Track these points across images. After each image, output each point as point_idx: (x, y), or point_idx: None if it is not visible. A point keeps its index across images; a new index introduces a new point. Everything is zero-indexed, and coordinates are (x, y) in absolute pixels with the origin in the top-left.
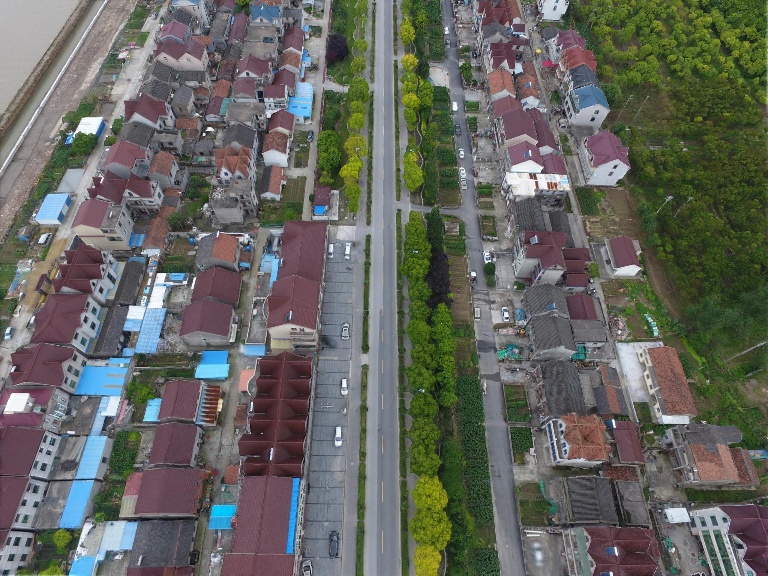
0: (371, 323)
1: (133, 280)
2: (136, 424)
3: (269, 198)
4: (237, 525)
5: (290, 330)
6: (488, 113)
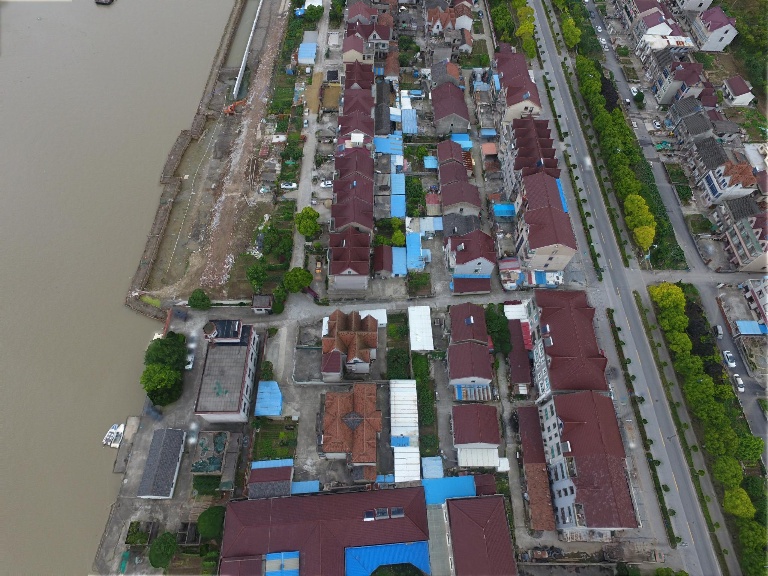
0: (561, 125)
1: (387, 92)
2: (417, 172)
3: (464, 51)
4: (528, 198)
5: (522, 110)
6: (613, 4)
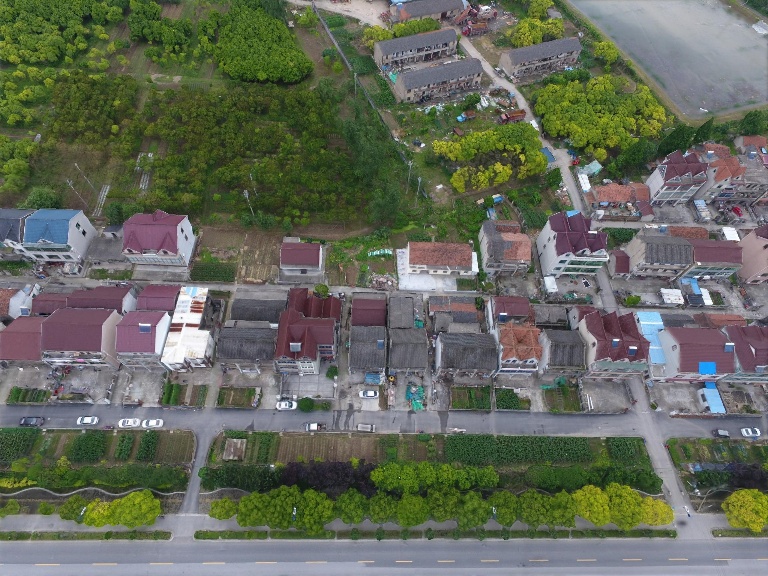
0: None
1: None
2: None
3: None
4: None
5: None
6: (8, 368)
